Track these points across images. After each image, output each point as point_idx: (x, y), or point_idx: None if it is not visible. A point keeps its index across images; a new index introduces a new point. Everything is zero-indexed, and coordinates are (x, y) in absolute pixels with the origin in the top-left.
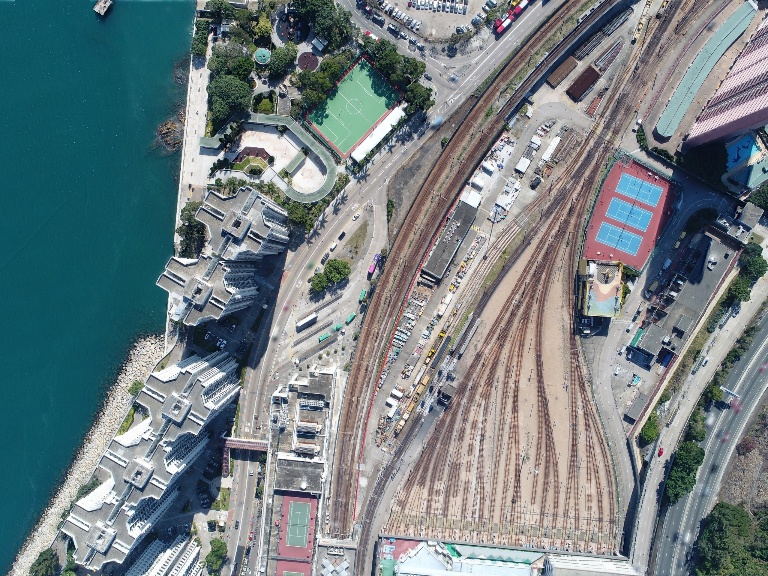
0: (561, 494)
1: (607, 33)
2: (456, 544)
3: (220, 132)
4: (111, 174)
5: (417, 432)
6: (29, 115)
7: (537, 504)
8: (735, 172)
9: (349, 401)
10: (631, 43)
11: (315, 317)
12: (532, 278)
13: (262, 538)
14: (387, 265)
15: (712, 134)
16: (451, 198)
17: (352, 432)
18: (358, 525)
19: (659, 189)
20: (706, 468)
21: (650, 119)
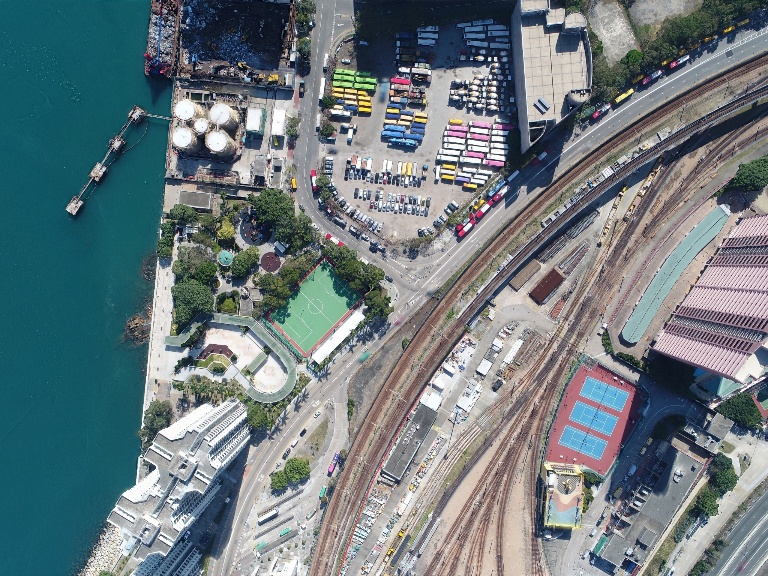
0: None
1: (572, 236)
2: None
3: (184, 331)
4: (78, 378)
5: None
6: (0, 324)
7: None
8: (705, 378)
9: None
10: (597, 246)
11: (276, 512)
12: (493, 479)
13: None
14: (347, 462)
15: (674, 357)
16: (411, 401)
17: None
18: None
19: (625, 394)
20: None
21: (616, 323)
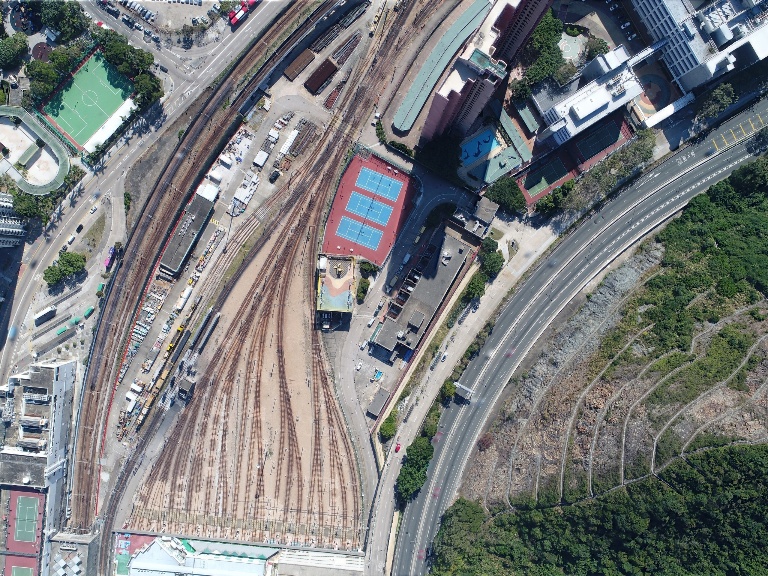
0: (305, 489)
1: (344, 26)
2: (191, 539)
3: None
4: None
5: (158, 427)
6: None
7: (281, 499)
8: (475, 167)
9: (89, 395)
10: (369, 36)
11: (52, 310)
12: (272, 272)
13: None
14: (125, 258)
15: (428, 128)
16: (186, 191)
17: (92, 426)
18: (100, 520)
19: (399, 183)
20: (446, 464)
21: (389, 113)
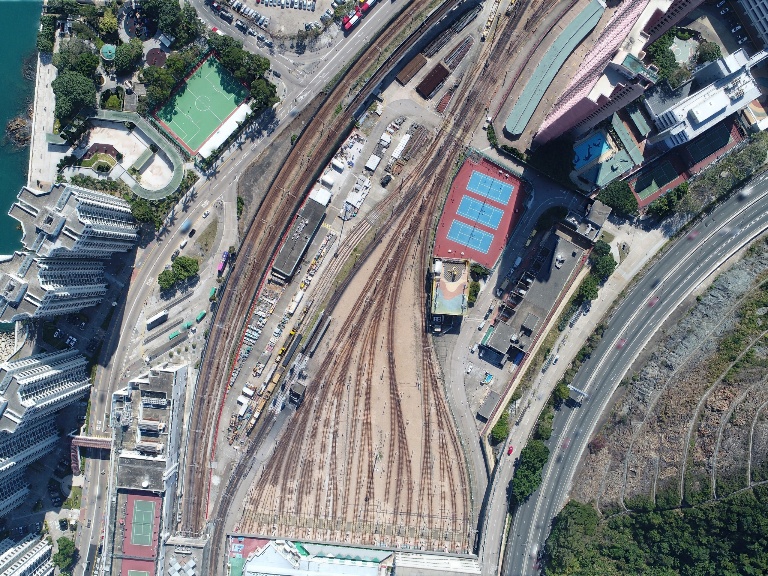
0: (414, 492)
1: (456, 30)
2: (305, 543)
3: (67, 128)
4: None
5: (269, 430)
6: None
7: (390, 502)
8: (586, 170)
9: (200, 399)
10: (481, 40)
11: (165, 315)
12: (383, 276)
13: (106, 537)
14: (237, 263)
15: (549, 132)
16: (299, 195)
17: (204, 430)
18: (211, 524)
19: (510, 187)
20: (557, 466)
21: (500, 117)
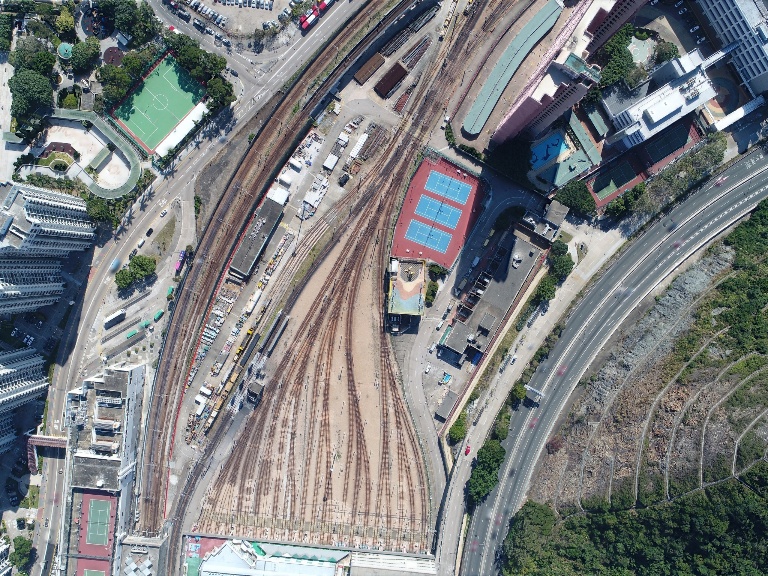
0: (373, 492)
1: (414, 30)
2: (261, 542)
3: (23, 127)
4: None
5: (227, 430)
6: None
7: (349, 502)
8: (544, 170)
9: (158, 398)
10: (439, 40)
11: (122, 314)
12: (341, 275)
13: (62, 536)
14: (195, 262)
15: (504, 131)
16: (257, 195)
17: (161, 430)
18: (169, 523)
19: (468, 187)
20: (515, 467)
21: (458, 116)
